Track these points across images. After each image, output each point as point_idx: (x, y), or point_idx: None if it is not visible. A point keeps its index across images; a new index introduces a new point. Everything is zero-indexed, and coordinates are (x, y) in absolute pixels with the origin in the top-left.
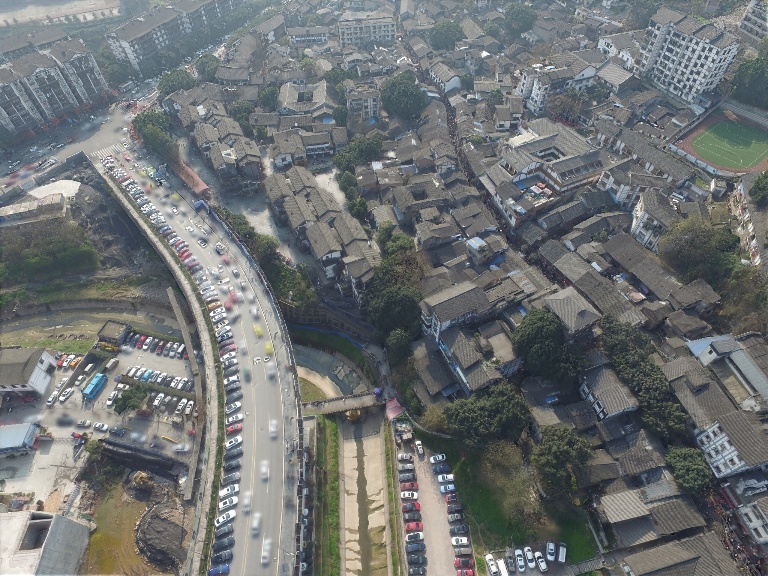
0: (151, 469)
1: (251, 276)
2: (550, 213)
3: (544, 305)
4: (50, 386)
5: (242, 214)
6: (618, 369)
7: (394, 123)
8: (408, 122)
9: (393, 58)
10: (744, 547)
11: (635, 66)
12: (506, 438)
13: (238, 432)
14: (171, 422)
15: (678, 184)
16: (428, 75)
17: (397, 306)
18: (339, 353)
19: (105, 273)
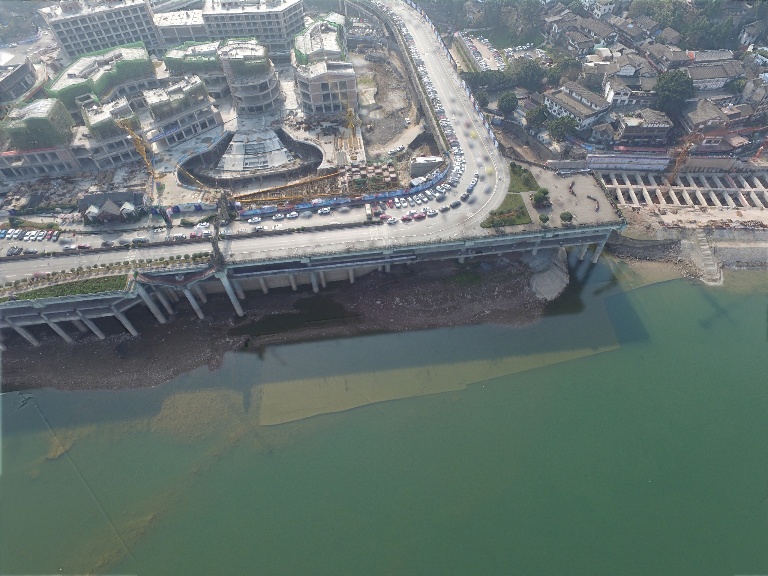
0: None
1: None
2: None
3: None
4: None
5: None
6: None
7: None
8: None
9: None
10: None
11: None
12: None
13: None
14: (365, 35)
15: None
16: None
17: None
18: None
19: None
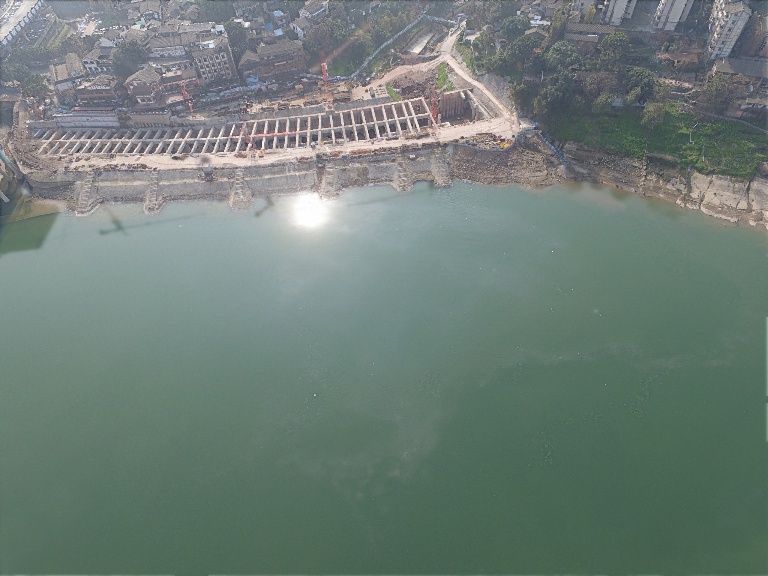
0: None
1: None
2: None
3: None
4: None
5: None
6: None
7: None
8: None
9: None
10: None
11: None
12: None
13: None
14: None
15: None
16: None
17: None
18: (81, 15)
19: None
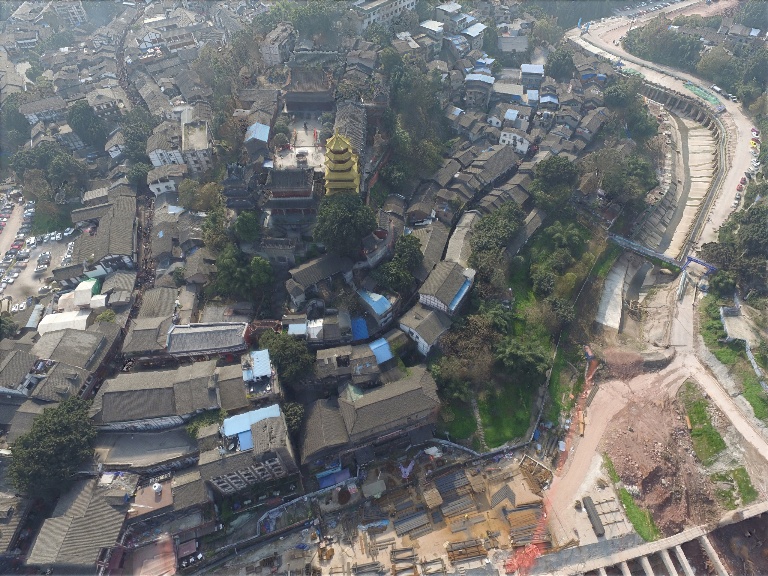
0: None
1: None
2: None
3: None
4: None
5: None
6: None
7: None
8: None
9: None
10: None
11: None
12: None
13: None
14: None
15: None
16: None
17: (13, 115)
18: (9, 168)
19: None
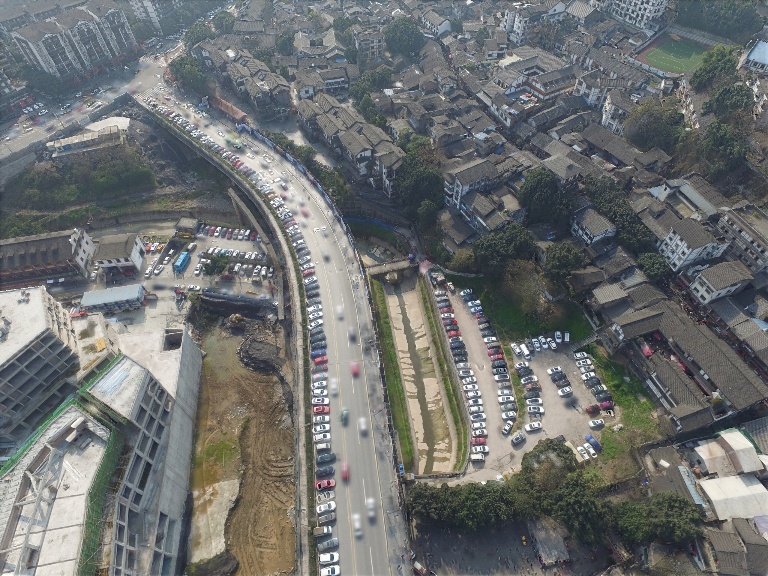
0: (241, 314)
1: (298, 175)
2: (537, 114)
3: (541, 167)
4: (143, 265)
5: (280, 132)
6: (599, 207)
7: (399, 59)
8: (409, 59)
9: (388, 11)
10: (695, 312)
11: (597, 3)
12: (520, 259)
13: (312, 274)
14: (251, 282)
15: (636, 86)
16: (421, 23)
17: (425, 182)
18: (374, 237)
19: (163, 190)
